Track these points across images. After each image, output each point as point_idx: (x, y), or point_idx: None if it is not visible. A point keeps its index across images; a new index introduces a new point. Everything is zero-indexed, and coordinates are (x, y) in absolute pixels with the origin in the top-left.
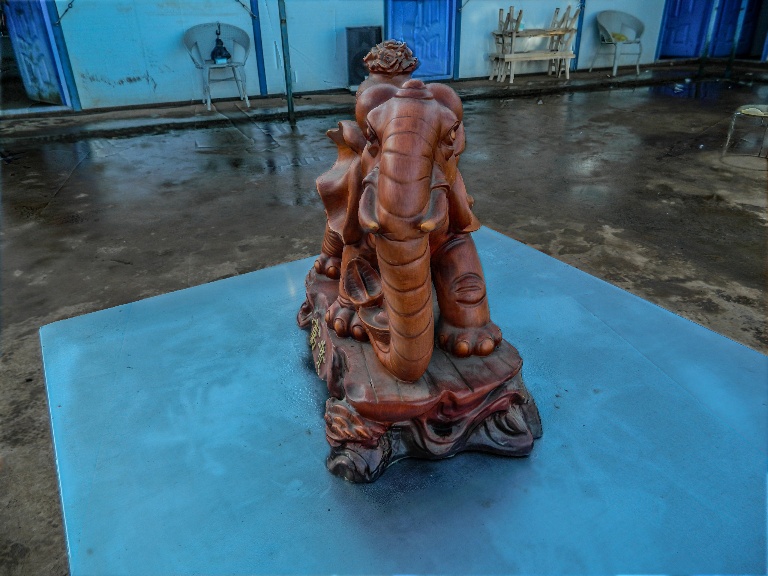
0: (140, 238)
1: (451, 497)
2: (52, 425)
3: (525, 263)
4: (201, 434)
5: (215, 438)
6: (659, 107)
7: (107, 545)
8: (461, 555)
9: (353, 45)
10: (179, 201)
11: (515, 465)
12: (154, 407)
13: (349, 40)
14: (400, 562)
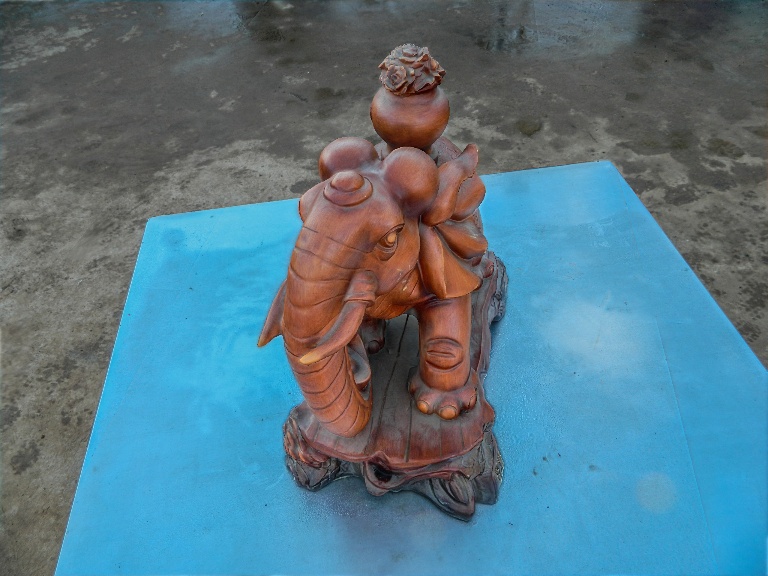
0: (323, 70)
1: (370, 536)
2: (118, 333)
3: (634, 253)
4: (210, 384)
5: (218, 393)
6: None
7: (107, 468)
8: None
9: None
10: (373, 26)
11: (449, 525)
12: (190, 341)
13: None
14: None
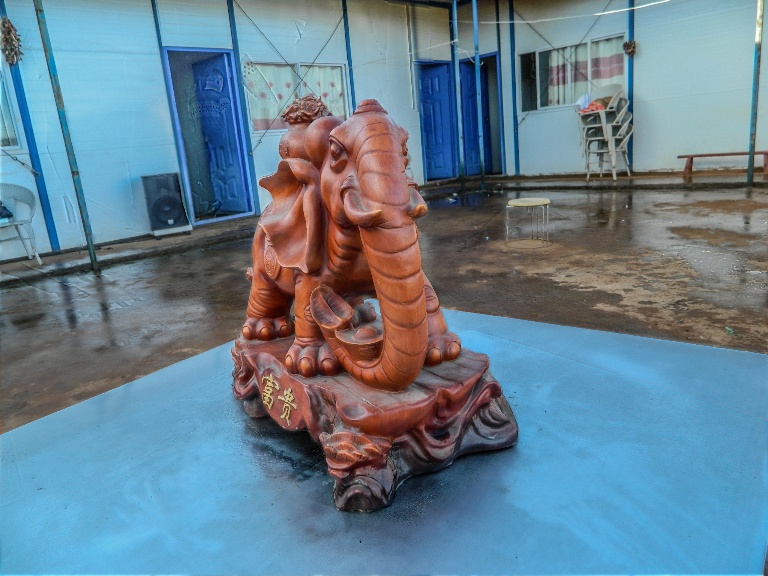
0: None
1: (471, 494)
2: None
3: None
4: (173, 522)
5: (193, 520)
6: (442, 215)
7: None
8: (510, 534)
9: (151, 192)
10: None
11: (509, 455)
12: (96, 515)
13: (146, 188)
14: (459, 559)
